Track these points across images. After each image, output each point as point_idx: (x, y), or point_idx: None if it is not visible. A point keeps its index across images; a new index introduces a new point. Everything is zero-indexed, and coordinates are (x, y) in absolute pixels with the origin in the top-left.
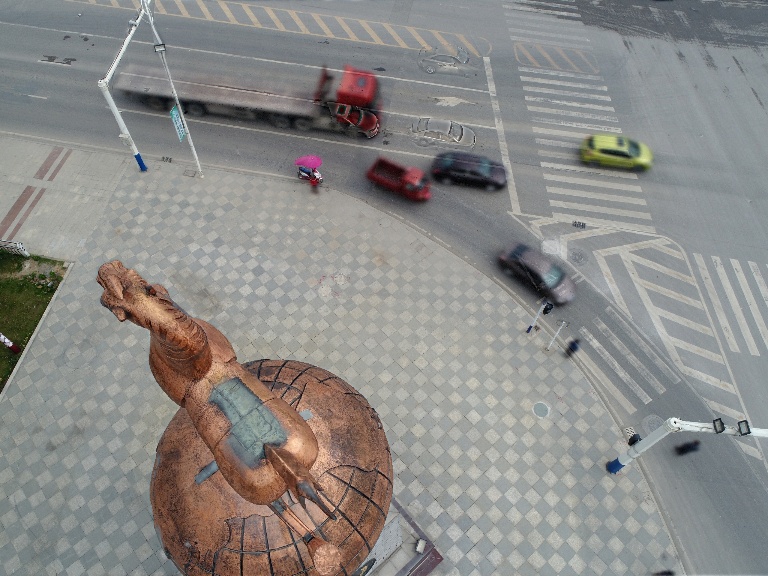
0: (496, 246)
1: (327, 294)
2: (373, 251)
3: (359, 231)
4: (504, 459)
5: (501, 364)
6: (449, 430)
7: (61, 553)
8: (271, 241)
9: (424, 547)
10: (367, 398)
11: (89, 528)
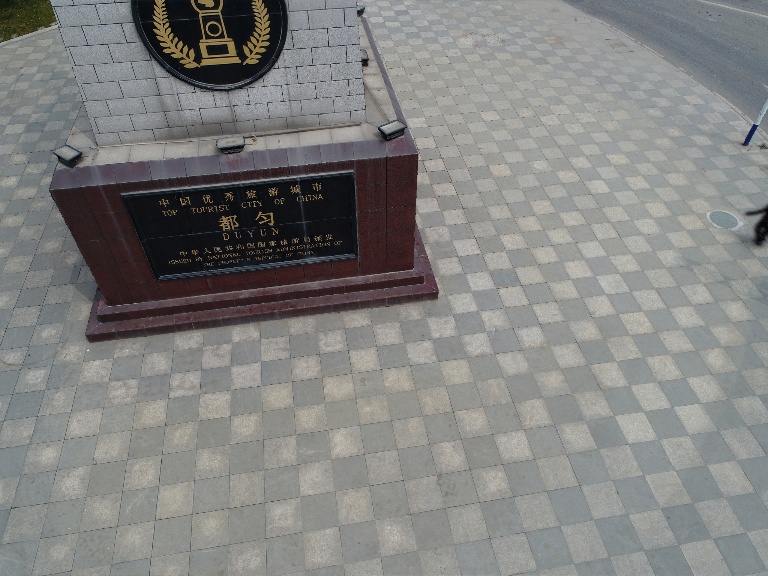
0: (735, 71)
1: (467, 43)
2: (551, 32)
3: (544, 17)
4: (622, 242)
5: (678, 157)
6: (548, 185)
7: (18, 114)
8: (434, 0)
9: (396, 129)
10: (450, 123)
11: (60, 108)
